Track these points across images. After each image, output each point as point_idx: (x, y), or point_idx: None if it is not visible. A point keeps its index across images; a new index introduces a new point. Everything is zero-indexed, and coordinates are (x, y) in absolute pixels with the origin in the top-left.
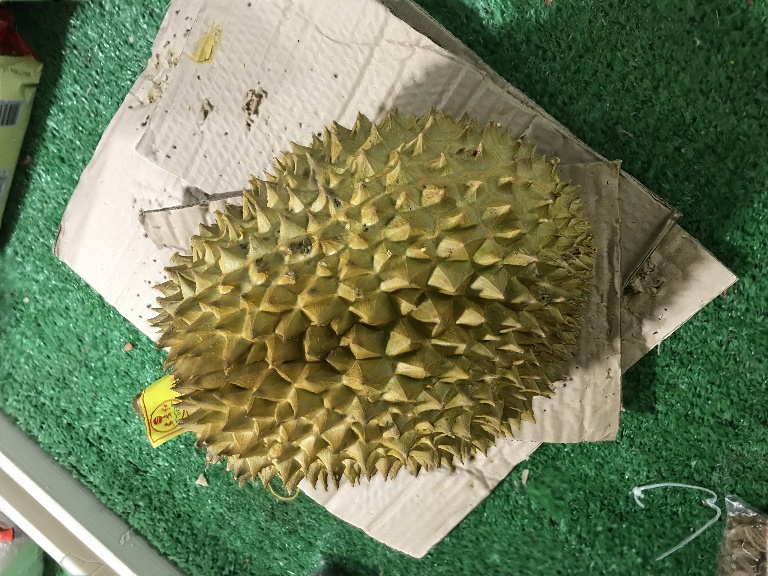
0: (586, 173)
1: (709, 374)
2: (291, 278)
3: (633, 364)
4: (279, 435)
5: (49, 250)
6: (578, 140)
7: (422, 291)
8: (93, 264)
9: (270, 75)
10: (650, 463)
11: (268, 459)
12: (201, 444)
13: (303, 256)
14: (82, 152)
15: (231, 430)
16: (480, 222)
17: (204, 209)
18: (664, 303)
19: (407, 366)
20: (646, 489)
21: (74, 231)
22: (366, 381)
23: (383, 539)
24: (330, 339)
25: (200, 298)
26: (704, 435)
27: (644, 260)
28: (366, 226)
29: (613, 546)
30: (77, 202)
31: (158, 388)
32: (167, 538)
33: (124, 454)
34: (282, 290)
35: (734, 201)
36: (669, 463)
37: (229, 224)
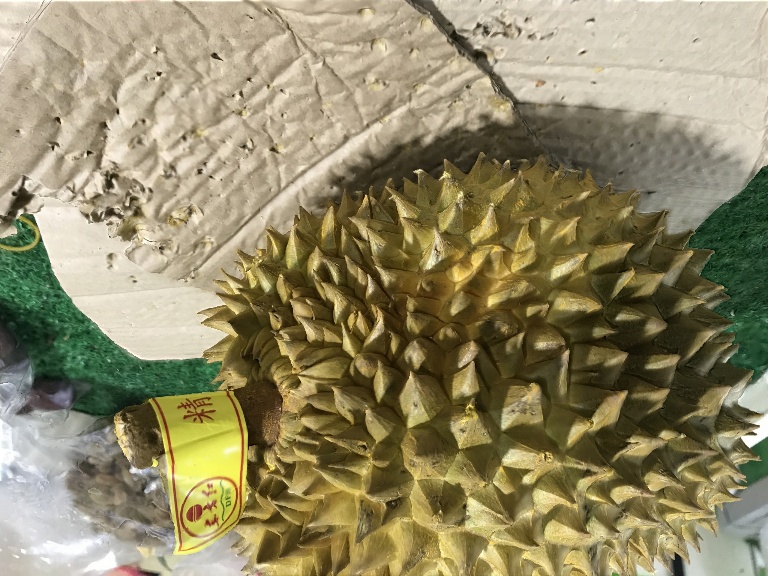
0: None
1: None
2: None
3: None
4: None
5: None
6: None
7: None
8: None
9: None
10: None
11: None
12: None
13: None
14: None
15: None
16: None
17: None
18: None
19: None
20: None
21: None
22: None
23: (118, 341)
24: None
25: None
26: None
27: None
28: None
29: None
30: None
31: (208, 454)
32: None
33: None
34: None
35: None
36: None
37: None
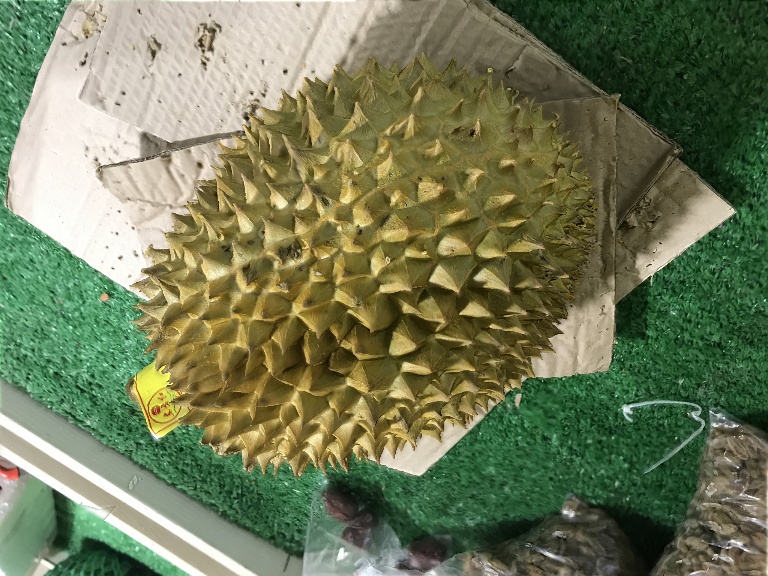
0: (582, 110)
1: (700, 301)
2: (284, 289)
3: (625, 295)
4: (286, 434)
5: (0, 202)
6: (573, 71)
7: (423, 288)
8: (52, 217)
9: (222, 6)
10: (639, 383)
11: (276, 452)
12: (206, 441)
13: (293, 261)
14: (17, 95)
15: (237, 434)
16: (482, 214)
17: (166, 160)
18: (659, 237)
19: (412, 365)
20: (635, 407)
21: (25, 183)
22: (372, 387)
23: (384, 462)
24: (330, 343)
25: (187, 309)
26: (692, 356)
27: (641, 198)
28: (359, 227)
29: (602, 455)
30: (22, 152)
31: (150, 376)
32: (173, 470)
33: (117, 397)
34: (275, 298)
35: (736, 130)
36: (657, 382)
37: (206, 223)
